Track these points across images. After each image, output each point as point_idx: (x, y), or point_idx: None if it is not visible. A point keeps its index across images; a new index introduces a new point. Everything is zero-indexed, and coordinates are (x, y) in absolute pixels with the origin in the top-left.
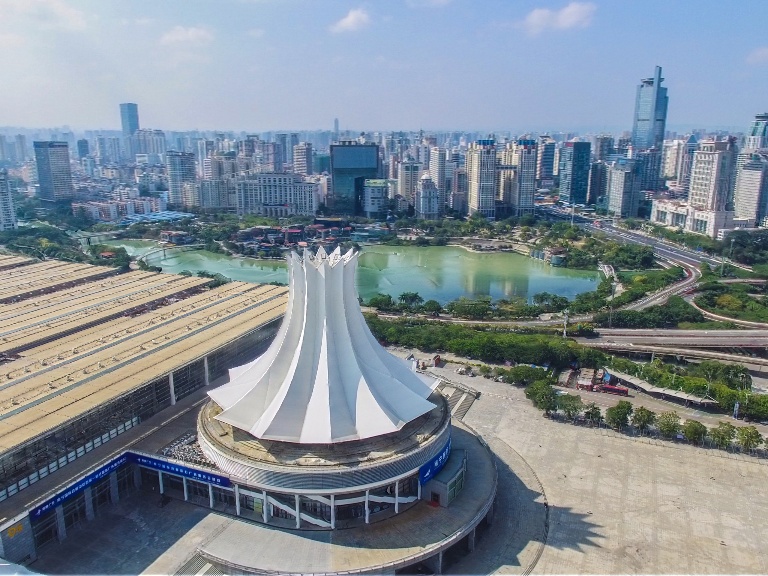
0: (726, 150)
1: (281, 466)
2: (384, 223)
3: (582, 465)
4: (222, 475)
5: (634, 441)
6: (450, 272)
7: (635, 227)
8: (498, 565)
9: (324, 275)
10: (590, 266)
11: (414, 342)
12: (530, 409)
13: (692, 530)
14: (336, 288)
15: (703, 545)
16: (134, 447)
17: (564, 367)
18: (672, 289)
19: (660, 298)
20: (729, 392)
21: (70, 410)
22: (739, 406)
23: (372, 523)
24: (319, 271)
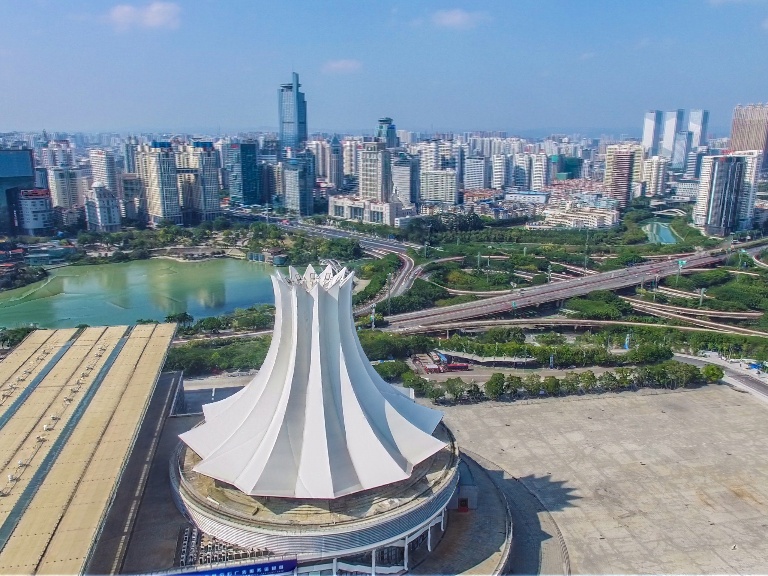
0: (386, 150)
1: (365, 521)
2: (64, 240)
3: (504, 437)
4: (286, 559)
5: (516, 405)
6: (180, 286)
7: (322, 222)
8: (538, 544)
9: (338, 297)
10: (312, 262)
11: (250, 363)
12: (417, 401)
13: (618, 461)
14: (344, 310)
15: (635, 470)
16: (127, 572)
17: (402, 357)
18: (404, 274)
19: (404, 283)
20: (540, 349)
21: (65, 550)
22: (554, 358)
23: (434, 549)
24: (330, 294)
